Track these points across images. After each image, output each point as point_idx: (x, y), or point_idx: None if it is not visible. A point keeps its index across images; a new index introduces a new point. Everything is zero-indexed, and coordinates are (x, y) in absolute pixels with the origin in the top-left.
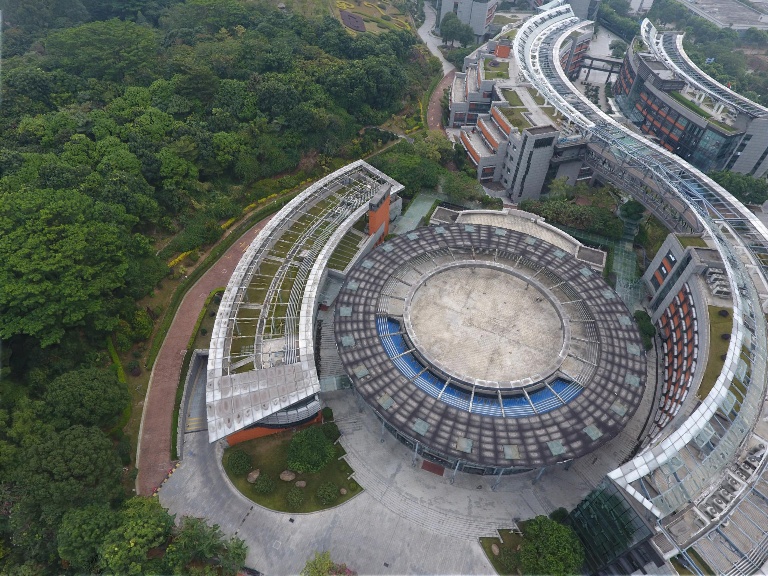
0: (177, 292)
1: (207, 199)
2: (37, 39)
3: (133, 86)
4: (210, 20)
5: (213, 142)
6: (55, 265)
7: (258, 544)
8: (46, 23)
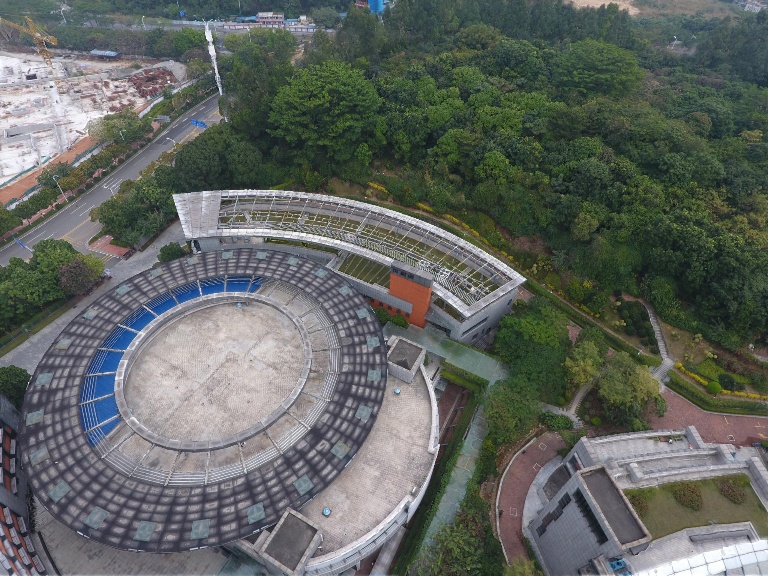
0: (351, 197)
1: (439, 182)
2: (677, 67)
3: (549, 96)
4: (758, 116)
5: (486, 154)
6: (293, 101)
7: (145, 257)
8: (708, 62)
